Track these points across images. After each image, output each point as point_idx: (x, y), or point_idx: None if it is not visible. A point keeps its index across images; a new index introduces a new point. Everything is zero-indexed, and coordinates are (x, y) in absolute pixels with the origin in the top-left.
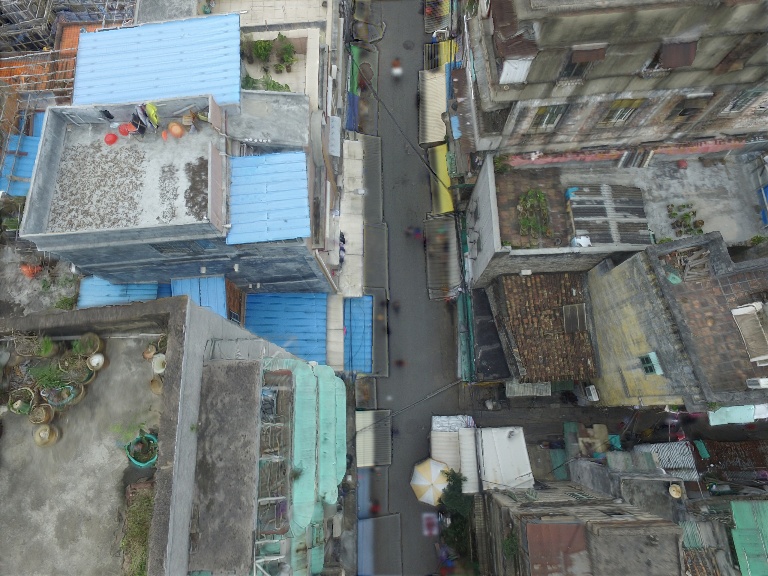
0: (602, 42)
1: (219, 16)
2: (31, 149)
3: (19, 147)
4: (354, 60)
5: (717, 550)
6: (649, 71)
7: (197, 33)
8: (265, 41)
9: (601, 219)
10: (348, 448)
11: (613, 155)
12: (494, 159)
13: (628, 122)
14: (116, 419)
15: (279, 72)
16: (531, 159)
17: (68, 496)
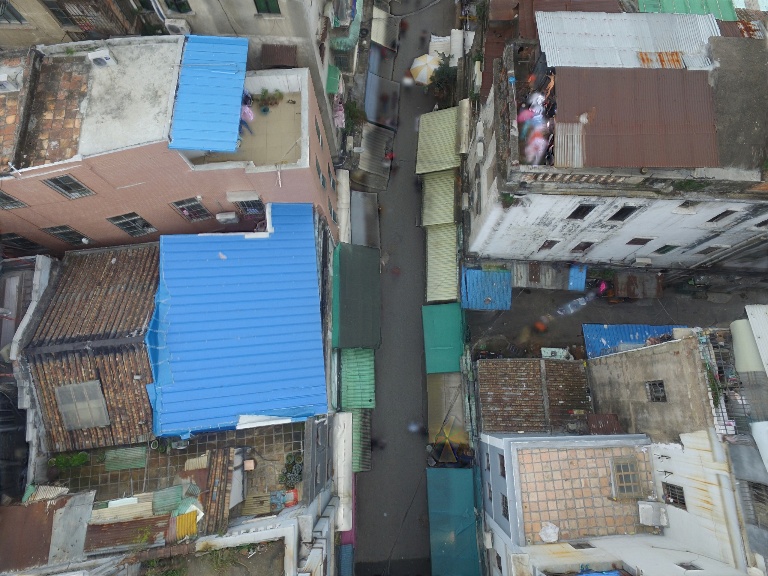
0: None
1: None
2: None
3: None
4: None
5: None
6: None
7: None
8: None
9: None
10: (366, 25)
11: None
12: None
13: None
14: None
15: None
16: None
17: None
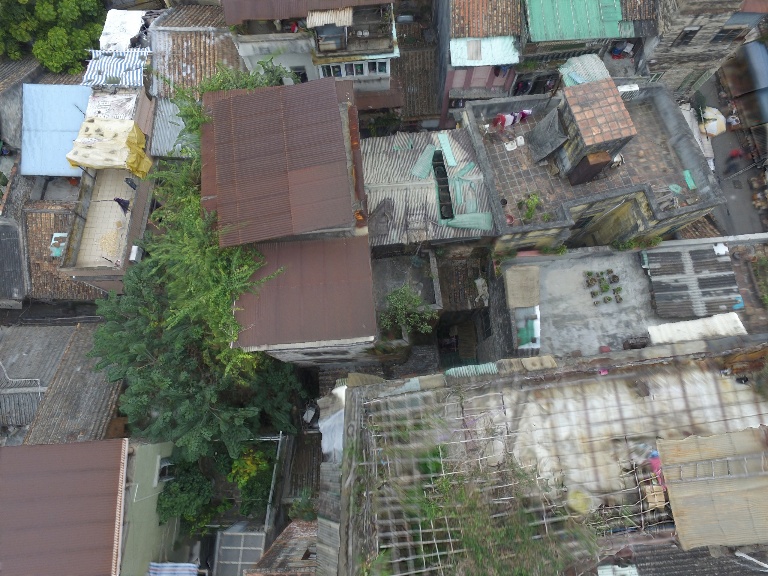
0: None
1: None
2: None
3: None
4: None
5: None
6: None
7: None
8: None
9: (705, 275)
10: None
11: None
12: None
13: None
14: None
15: None
16: None
17: None
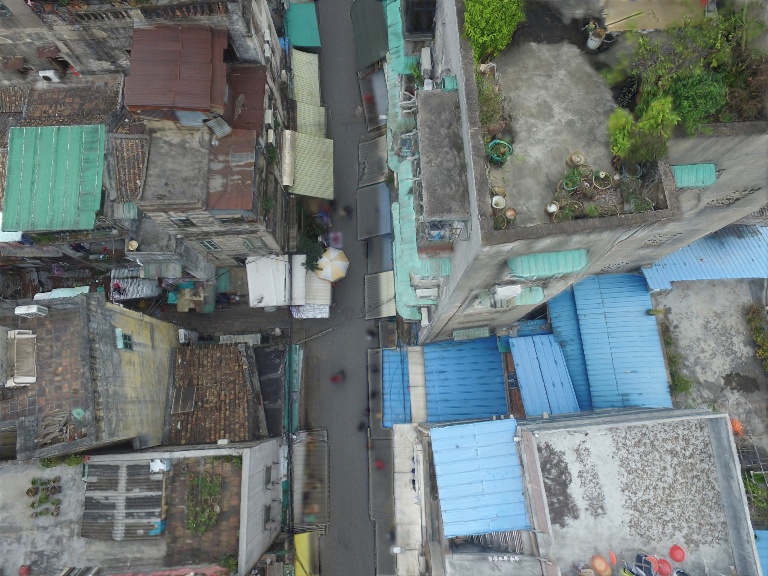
0: None
1: None
2: None
3: None
4: None
5: (114, 200)
6: None
7: None
8: None
9: (133, 494)
10: None
11: None
12: (237, 569)
13: None
14: (529, 174)
15: None
16: (194, 574)
17: (550, 127)
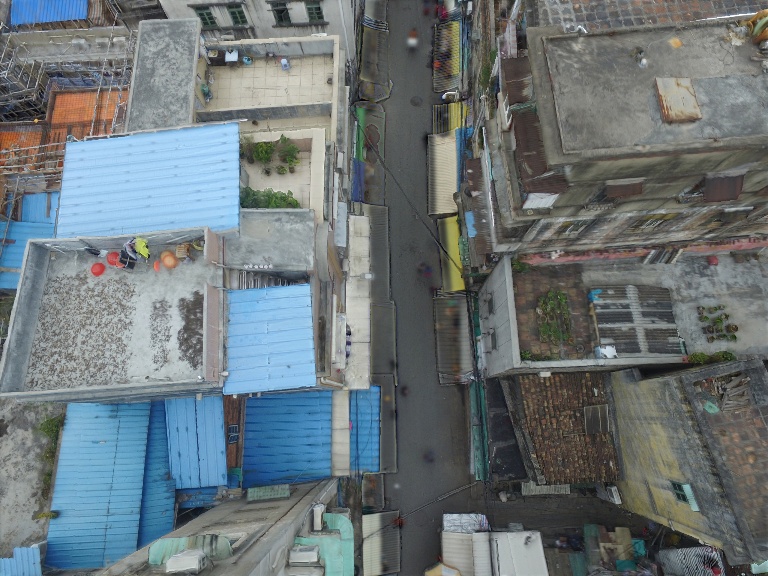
0: (639, 177)
1: (217, 125)
2: (19, 236)
3: (7, 235)
4: (360, 126)
5: None
6: (687, 196)
7: (193, 144)
8: (267, 142)
9: (627, 325)
10: None
11: (639, 253)
12: (512, 261)
13: (658, 228)
14: None
15: (282, 173)
16: (551, 258)
17: None
